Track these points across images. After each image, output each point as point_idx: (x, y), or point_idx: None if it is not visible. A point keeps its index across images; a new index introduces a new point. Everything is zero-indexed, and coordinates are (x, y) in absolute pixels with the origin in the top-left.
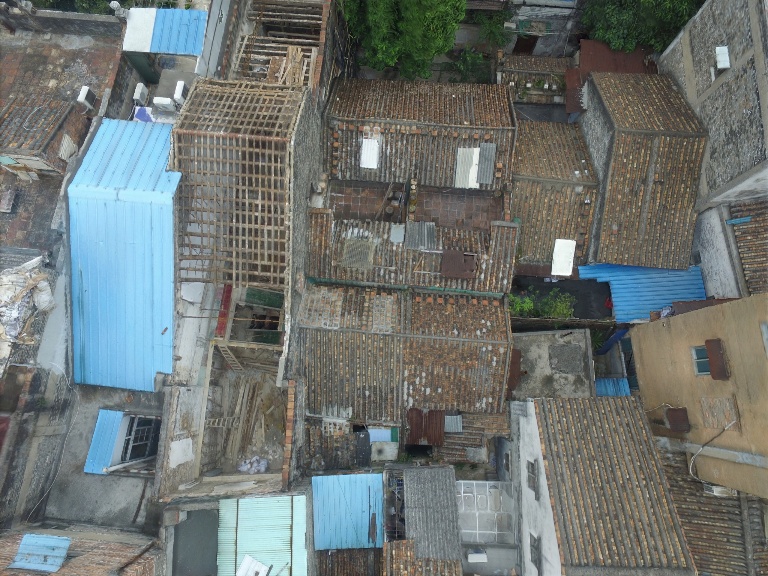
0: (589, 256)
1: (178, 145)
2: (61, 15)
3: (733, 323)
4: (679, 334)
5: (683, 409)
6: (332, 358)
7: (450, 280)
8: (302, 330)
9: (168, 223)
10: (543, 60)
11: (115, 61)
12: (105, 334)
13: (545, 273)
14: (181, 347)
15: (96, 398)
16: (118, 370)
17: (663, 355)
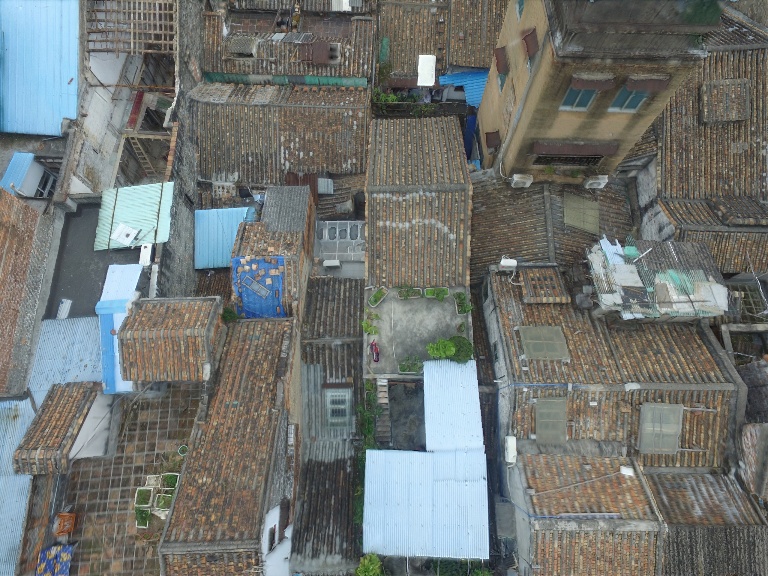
0: (446, 67)
1: None
2: None
3: (508, 24)
4: (493, 76)
5: (496, 131)
6: (220, 129)
7: (321, 68)
8: (194, 104)
9: None
10: None
11: None
12: (21, 87)
13: (412, 85)
14: (89, 114)
15: (13, 147)
16: (31, 118)
17: (489, 107)
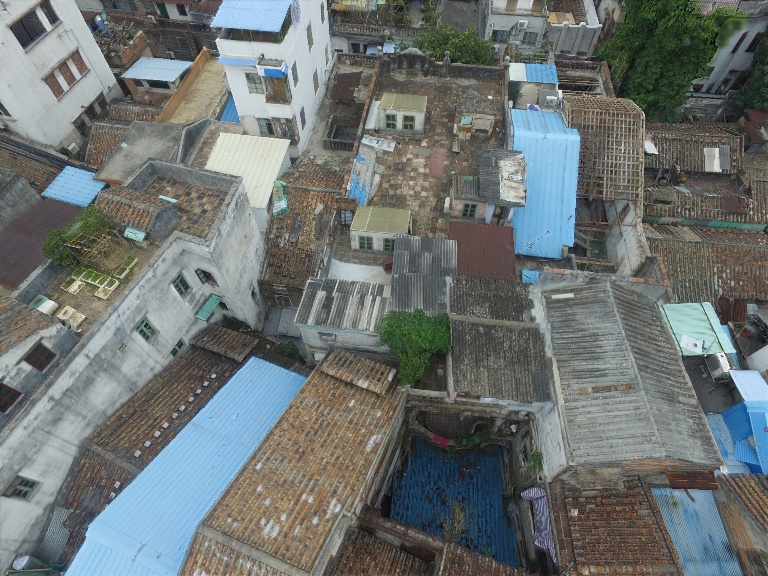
0: None
1: (572, 116)
2: (466, 65)
3: None
4: None
5: None
6: None
7: (728, 215)
8: None
9: (577, 151)
10: (717, 123)
11: (506, 85)
12: (528, 220)
13: None
14: None
15: (515, 265)
16: (535, 244)
17: None
